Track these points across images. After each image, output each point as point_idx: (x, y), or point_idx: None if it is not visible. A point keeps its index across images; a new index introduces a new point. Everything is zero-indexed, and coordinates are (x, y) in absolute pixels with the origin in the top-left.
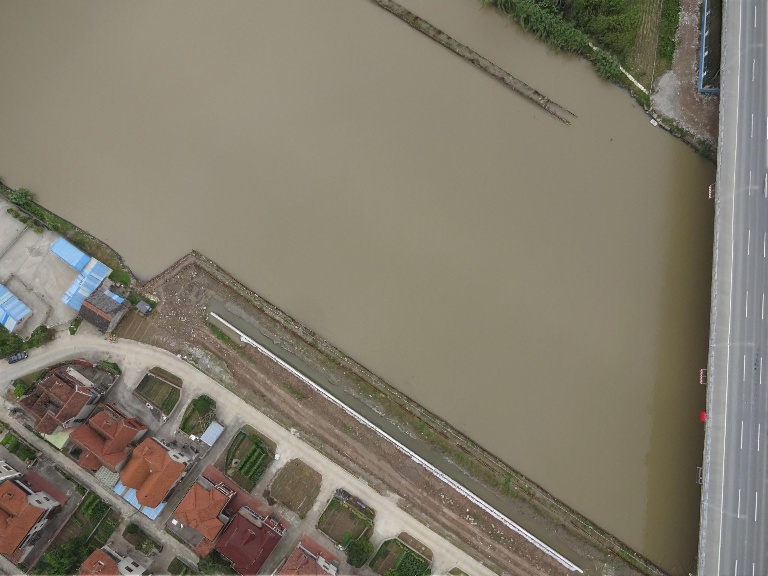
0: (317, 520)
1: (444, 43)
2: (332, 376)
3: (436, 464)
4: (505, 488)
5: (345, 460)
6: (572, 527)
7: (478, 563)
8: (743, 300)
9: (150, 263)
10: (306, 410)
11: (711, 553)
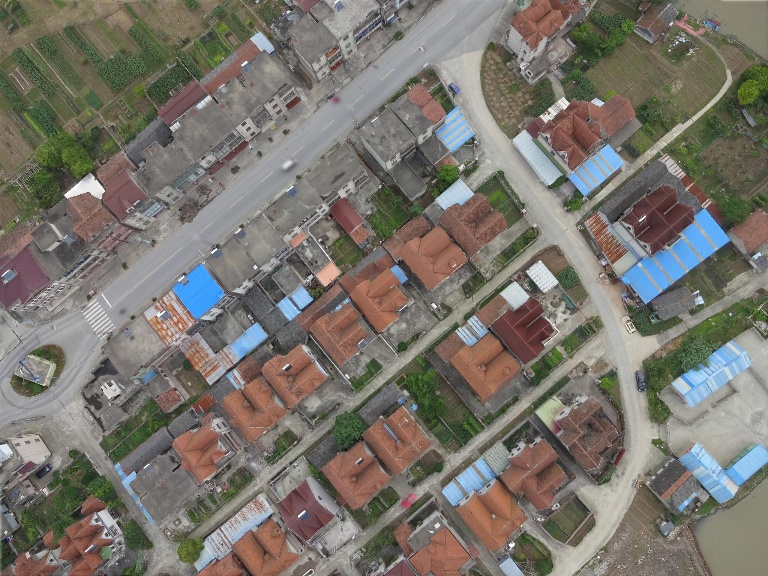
0: None
1: None
2: None
3: None
4: None
5: None
6: None
7: None
8: None
9: (714, 539)
10: None
11: None
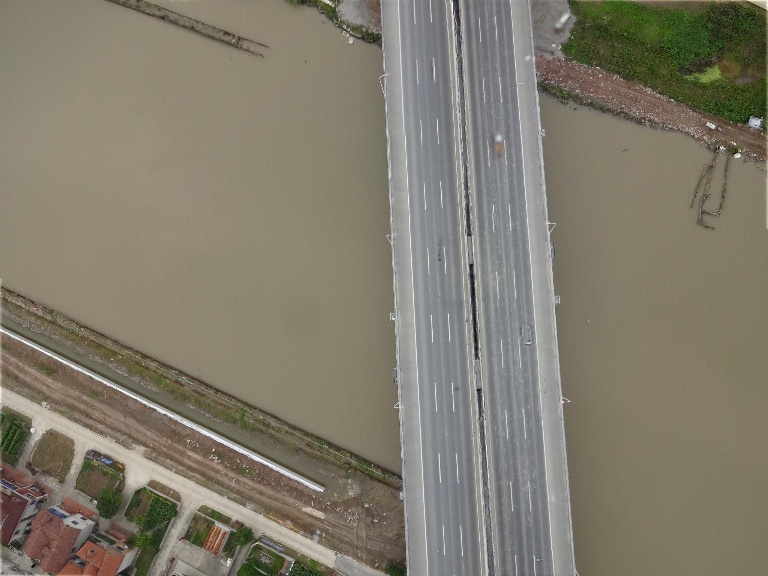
0: (73, 481)
1: (134, 7)
2: (78, 347)
3: (184, 412)
4: (243, 423)
5: (93, 423)
6: (308, 449)
7: (223, 498)
8: (420, 193)
9: None
10: (55, 383)
11: (413, 451)
